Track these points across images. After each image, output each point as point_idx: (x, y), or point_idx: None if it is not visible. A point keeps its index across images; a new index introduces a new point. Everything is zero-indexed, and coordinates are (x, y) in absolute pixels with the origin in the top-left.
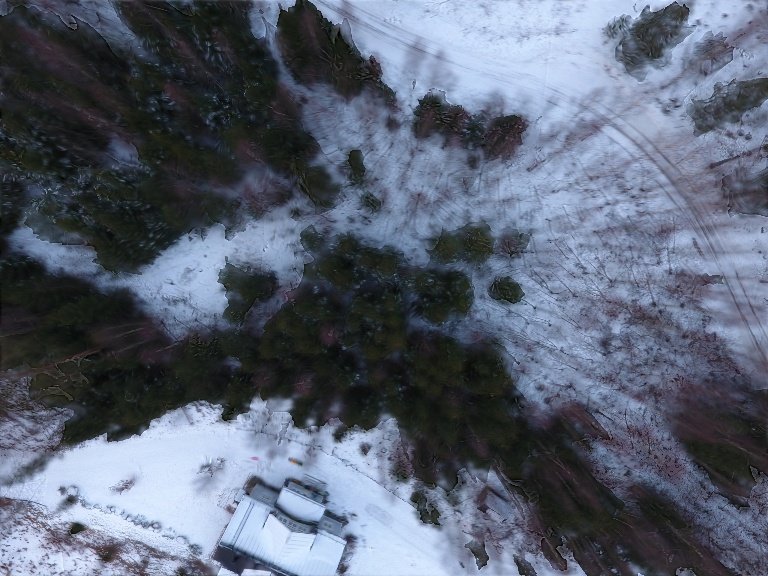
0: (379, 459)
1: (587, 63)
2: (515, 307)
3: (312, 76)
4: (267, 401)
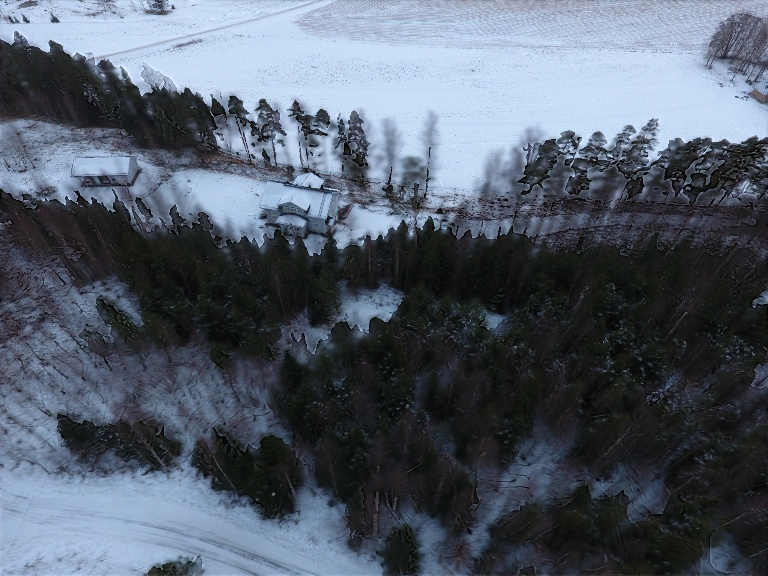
0: None
1: None
2: None
3: None
4: None
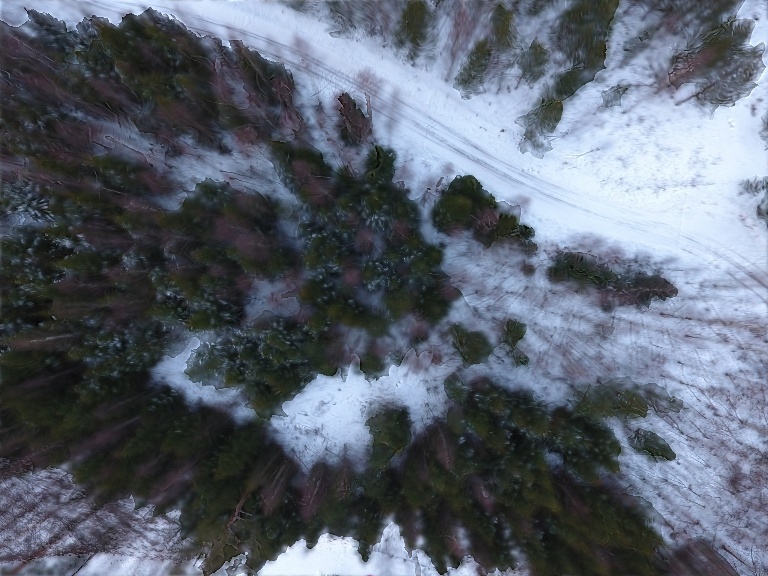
0: None
1: (722, 213)
2: None
3: (455, 227)
4: None
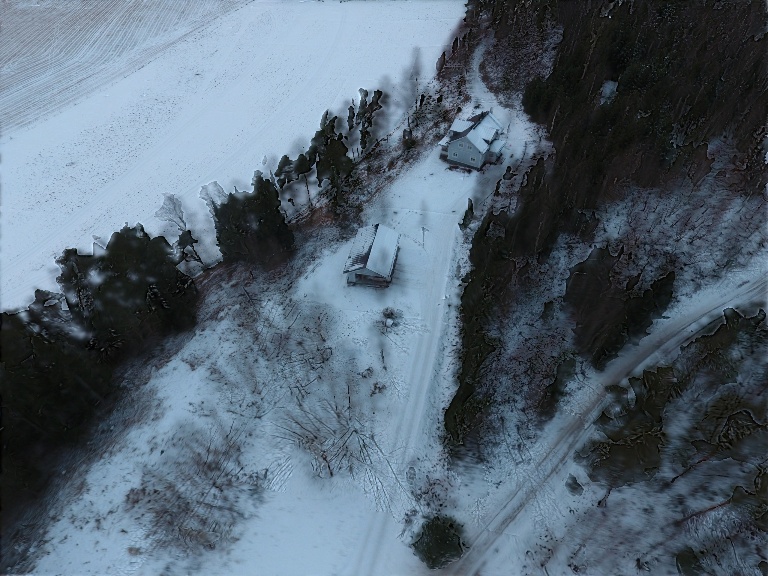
0: (521, 179)
1: None
2: (650, 205)
3: None
4: None
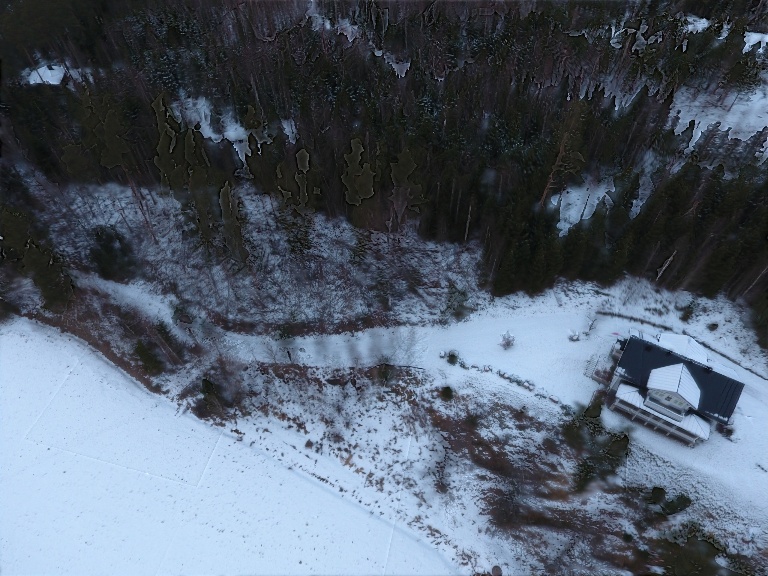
0: (727, 338)
1: None
2: None
3: None
4: (652, 242)
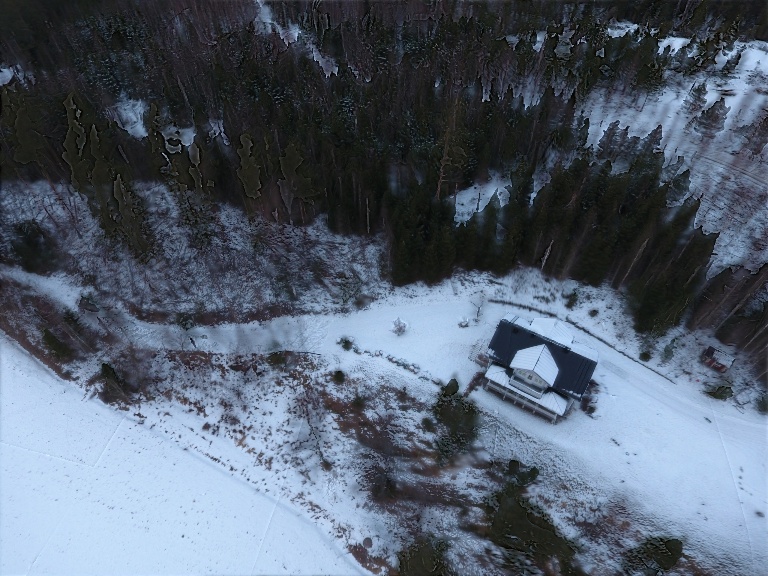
0: (606, 323)
1: (680, 140)
2: None
3: None
4: None
